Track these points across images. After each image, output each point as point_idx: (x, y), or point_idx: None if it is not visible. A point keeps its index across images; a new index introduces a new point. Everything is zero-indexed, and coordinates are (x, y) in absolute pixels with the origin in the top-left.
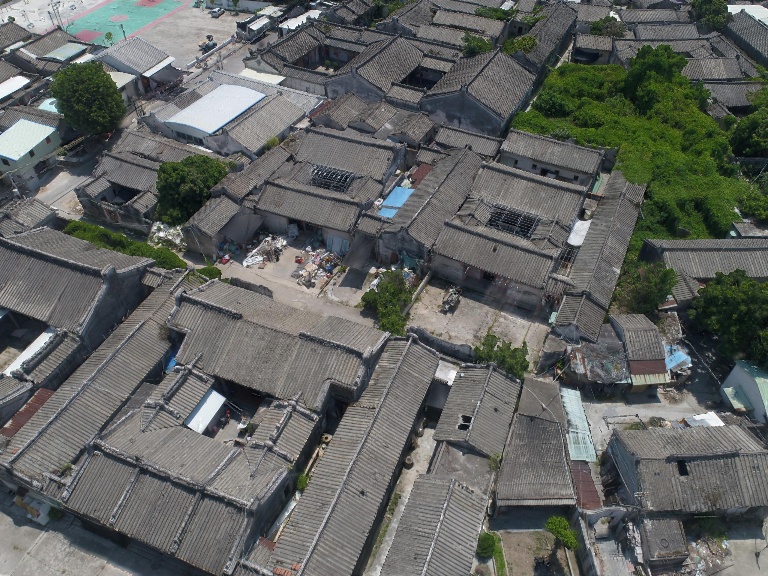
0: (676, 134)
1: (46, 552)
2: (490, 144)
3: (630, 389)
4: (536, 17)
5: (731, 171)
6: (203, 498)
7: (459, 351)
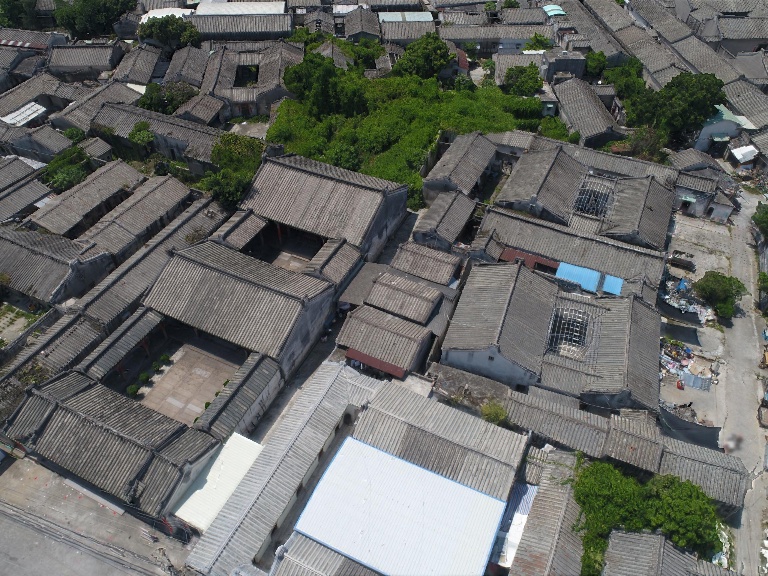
0: (414, 99)
1: None
2: (461, 200)
3: None
4: (129, 132)
5: (469, 88)
6: None
7: None
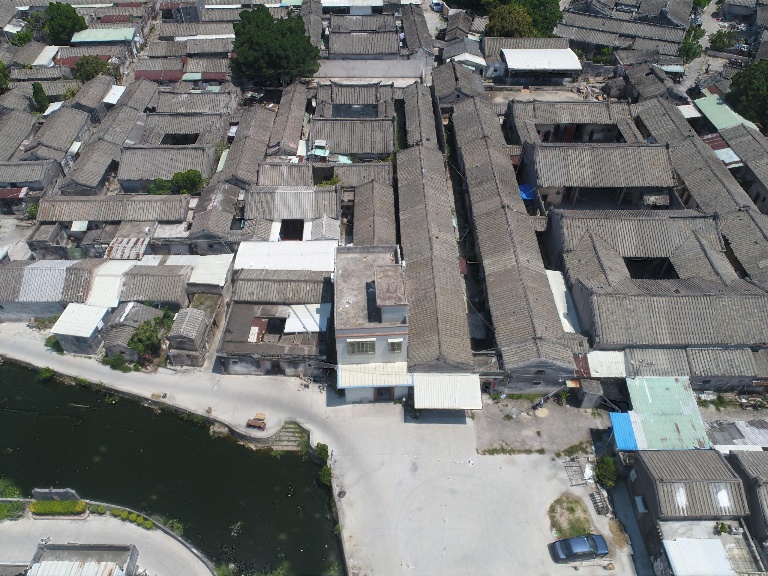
0: None
1: None
2: None
3: None
4: None
5: None
6: None
7: None
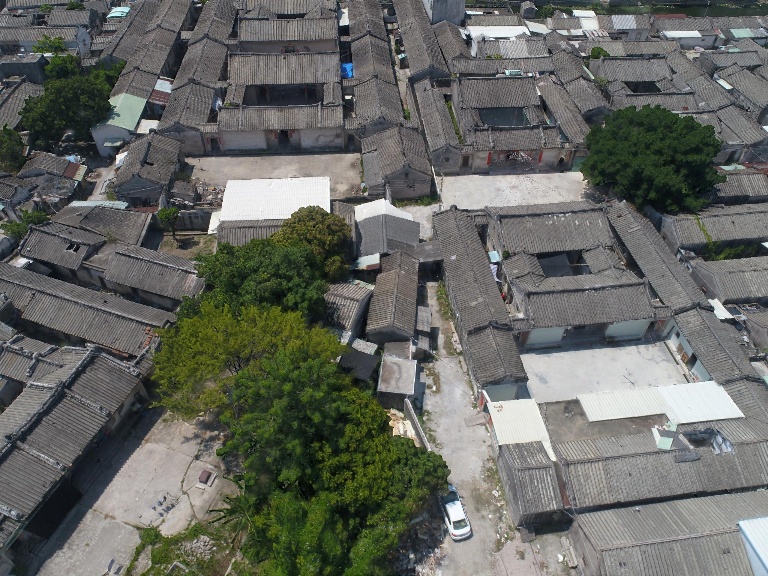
0: None
1: (60, 571)
2: None
3: (81, 188)
4: None
5: None
6: (70, 390)
7: (3, 250)
